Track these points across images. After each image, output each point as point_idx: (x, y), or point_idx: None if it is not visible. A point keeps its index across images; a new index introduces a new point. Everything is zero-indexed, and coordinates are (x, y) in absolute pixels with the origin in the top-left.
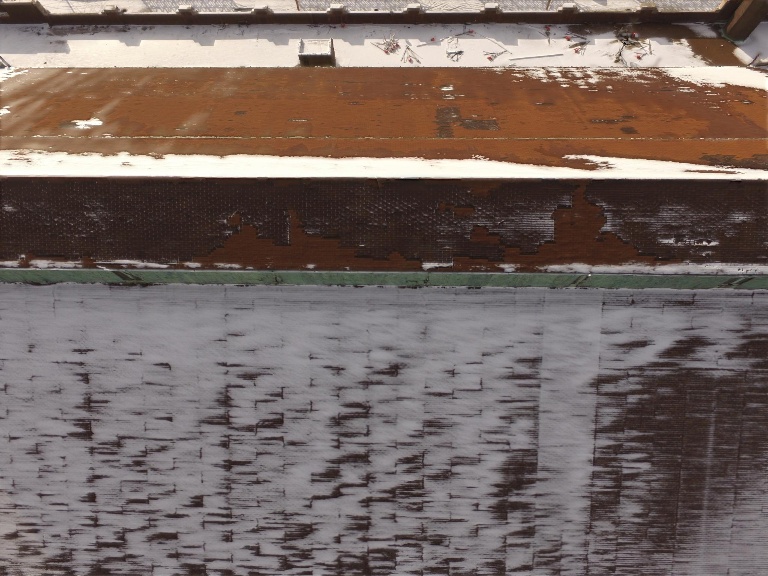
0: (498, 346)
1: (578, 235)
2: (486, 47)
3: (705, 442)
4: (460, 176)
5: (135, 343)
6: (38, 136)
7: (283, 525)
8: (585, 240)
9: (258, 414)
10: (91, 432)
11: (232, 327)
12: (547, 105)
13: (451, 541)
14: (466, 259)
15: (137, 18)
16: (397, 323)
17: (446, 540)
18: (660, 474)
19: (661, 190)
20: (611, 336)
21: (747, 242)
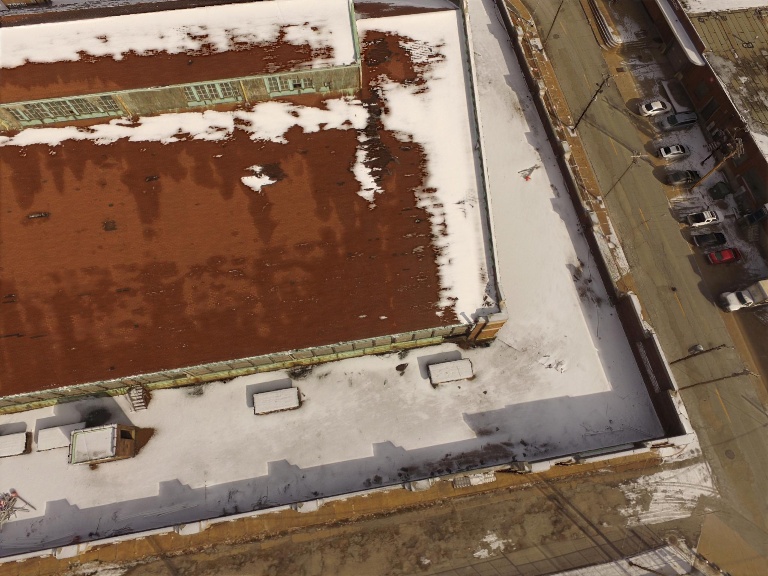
0: None
1: None
2: None
3: None
4: None
5: None
6: (218, 80)
7: None
8: None
9: None
10: None
11: None
12: None
13: None
14: None
15: None
16: None
17: None
18: None
19: None
20: None
21: None
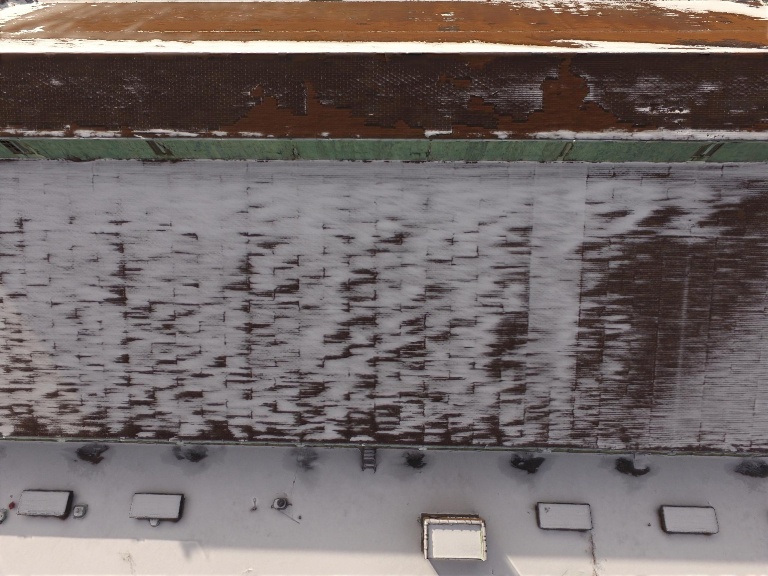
0: (493, 216)
1: (564, 104)
2: None
3: (680, 304)
4: (459, 51)
5: (165, 215)
6: None
7: (298, 384)
8: (570, 109)
9: (276, 280)
10: (125, 298)
11: (253, 199)
12: (541, 24)
13: (450, 398)
14: (464, 127)
15: None
16: (402, 195)
17: (445, 397)
18: (639, 334)
19: (638, 62)
20: (595, 206)
21: (715, 110)
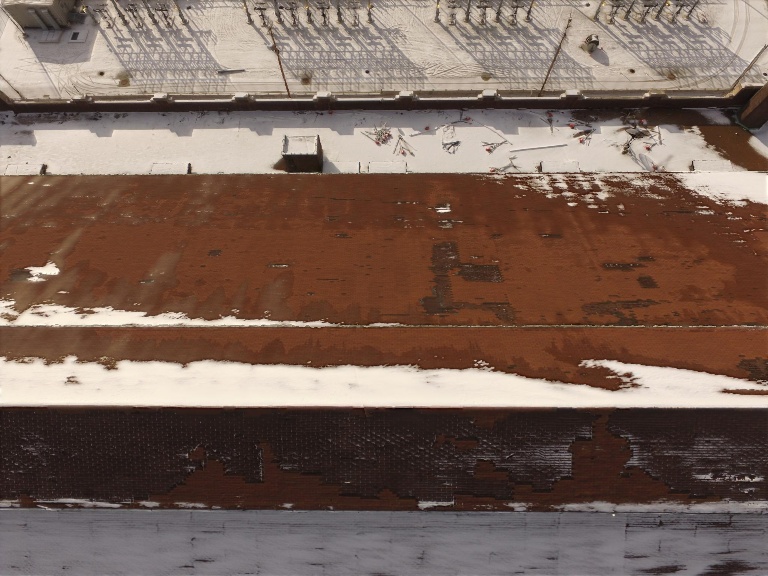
0: (506, 572)
1: (600, 470)
2: (484, 136)
3: None
4: (461, 404)
5: (88, 570)
6: None
7: None
8: (608, 476)
9: None
10: None
11: (200, 552)
12: (554, 238)
13: None
14: (469, 497)
15: (109, 106)
16: (390, 547)
17: None
18: None
19: (696, 420)
20: (636, 561)
21: None
